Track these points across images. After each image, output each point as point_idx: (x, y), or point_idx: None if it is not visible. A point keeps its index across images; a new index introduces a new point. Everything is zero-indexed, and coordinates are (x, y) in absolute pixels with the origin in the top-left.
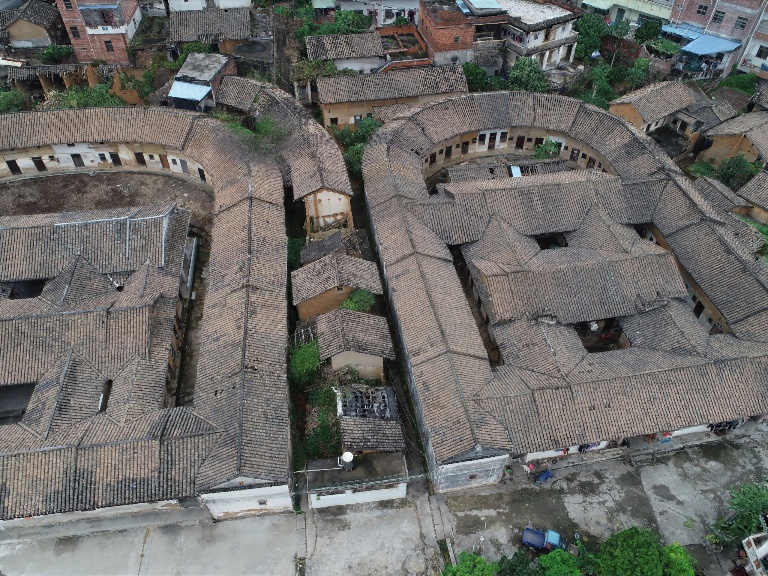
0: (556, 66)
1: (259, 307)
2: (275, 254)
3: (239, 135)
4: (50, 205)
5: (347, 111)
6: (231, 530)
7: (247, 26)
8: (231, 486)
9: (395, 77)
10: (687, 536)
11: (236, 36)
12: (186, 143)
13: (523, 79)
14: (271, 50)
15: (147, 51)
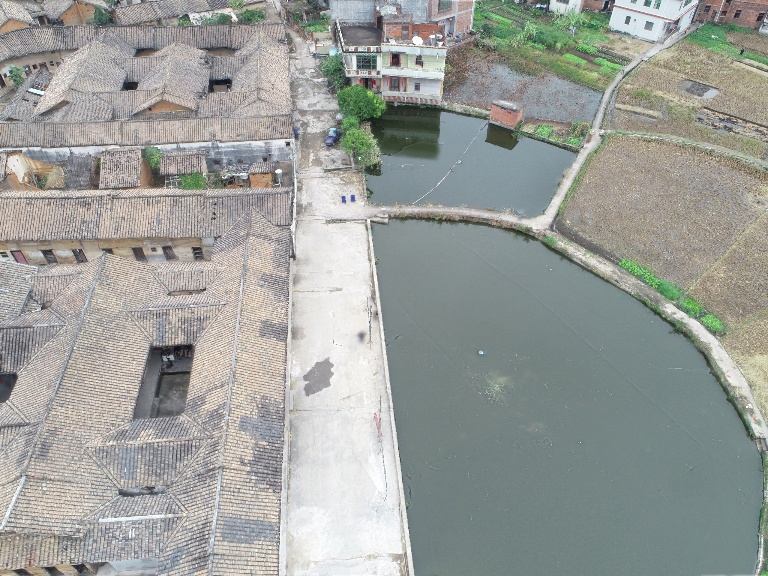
0: None
1: None
2: None
3: None
4: None
5: None
6: (303, 252)
7: None
8: None
9: None
10: (335, 104)
11: None
12: None
13: None
14: None
15: None
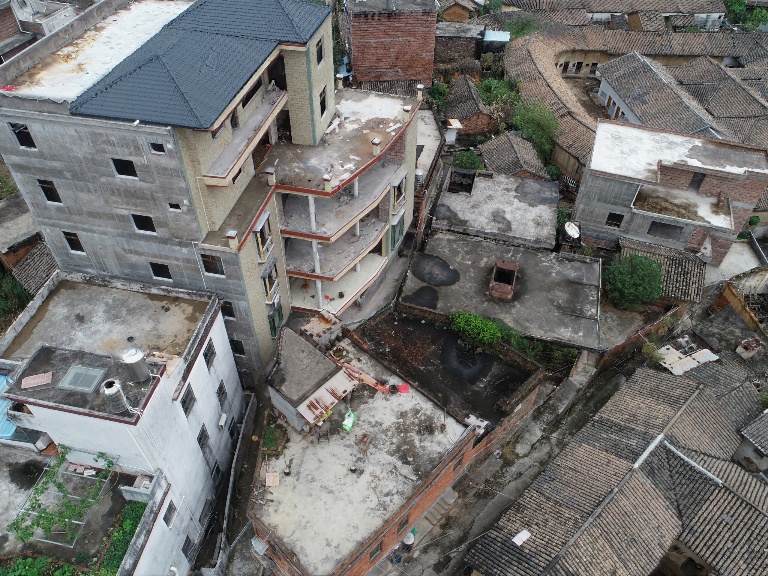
0: None
1: None
2: None
3: None
4: None
5: None
6: None
7: None
8: None
9: None
10: None
11: None
12: None
13: None
14: None
15: None
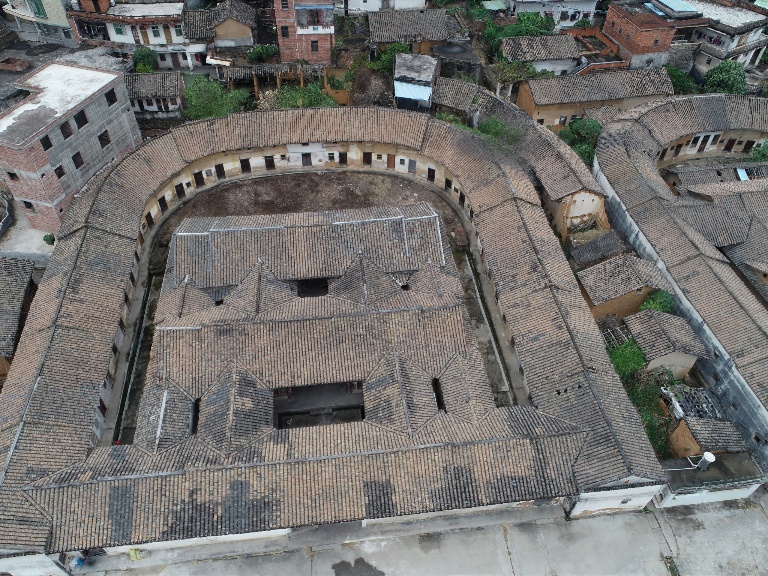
0: (743, 69)
1: (568, 307)
2: (556, 254)
3: (482, 136)
4: (288, 204)
5: (555, 112)
6: (587, 529)
7: (444, 27)
8: (615, 485)
9: (603, 79)
10: None
11: (435, 37)
12: (423, 143)
13: (730, 82)
14: (472, 51)
15: (350, 51)
